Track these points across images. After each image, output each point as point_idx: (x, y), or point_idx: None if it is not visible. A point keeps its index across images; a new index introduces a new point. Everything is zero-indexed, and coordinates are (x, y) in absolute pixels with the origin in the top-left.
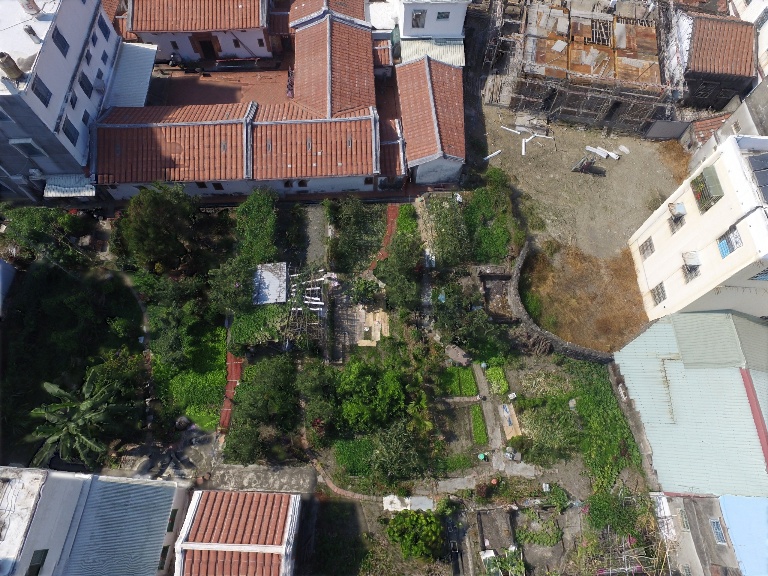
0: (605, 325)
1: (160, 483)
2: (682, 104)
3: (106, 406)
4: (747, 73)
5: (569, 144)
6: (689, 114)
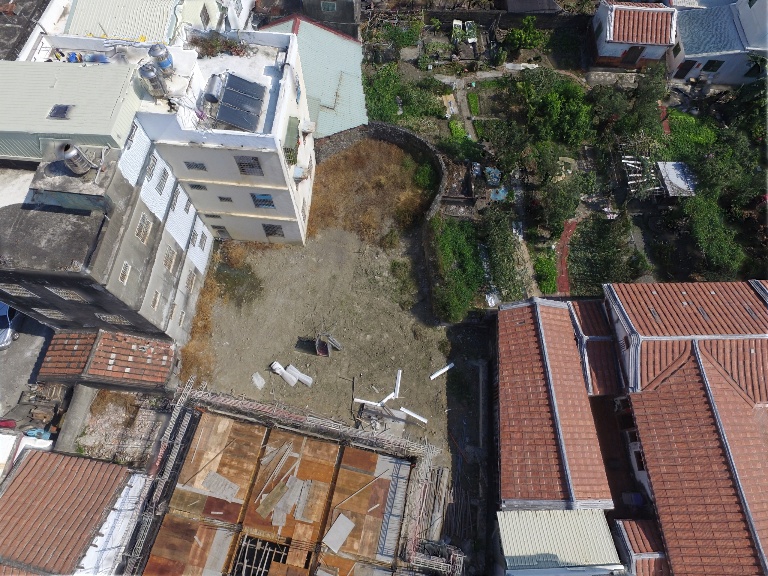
0: (359, 161)
1: (697, 55)
2: (137, 463)
3: (761, 92)
4: (38, 456)
5: (333, 391)
6: (132, 447)
